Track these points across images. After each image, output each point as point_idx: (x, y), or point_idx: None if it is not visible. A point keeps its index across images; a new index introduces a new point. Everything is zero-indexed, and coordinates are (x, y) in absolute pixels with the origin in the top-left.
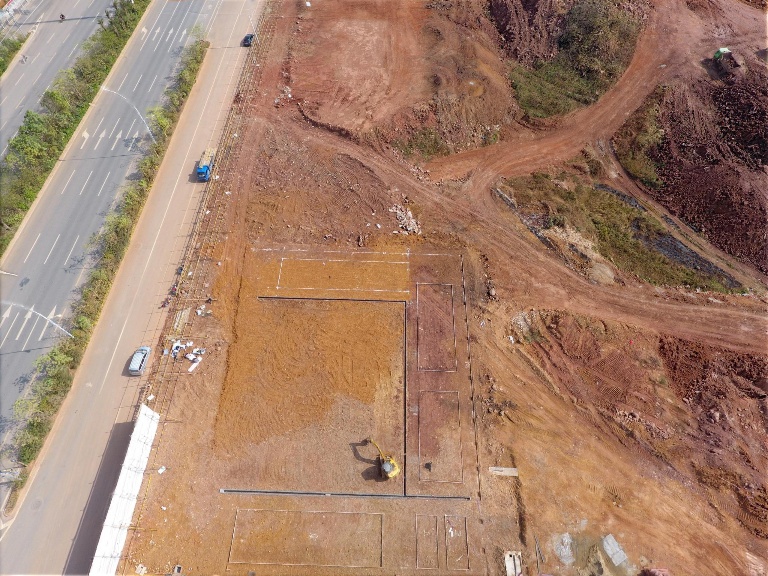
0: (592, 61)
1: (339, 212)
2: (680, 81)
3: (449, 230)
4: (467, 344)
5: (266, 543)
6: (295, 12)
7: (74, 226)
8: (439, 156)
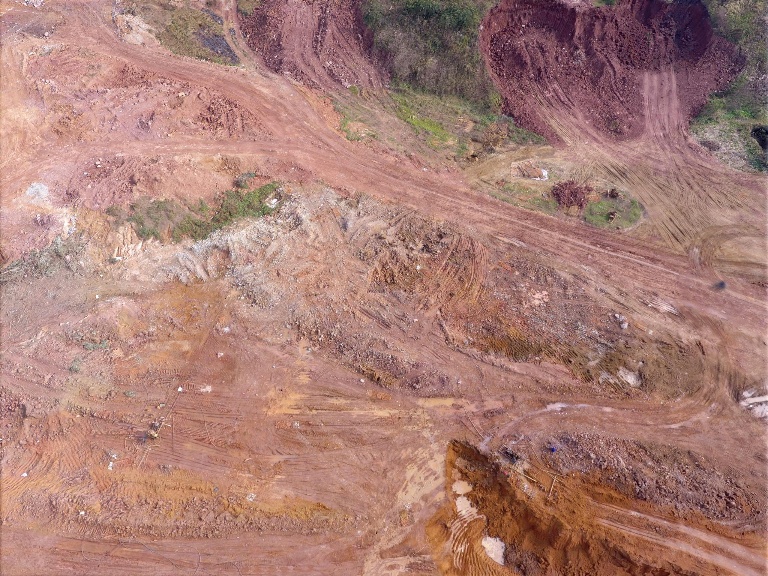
0: None
1: None
2: None
3: None
4: None
5: None
6: None
7: None
8: None
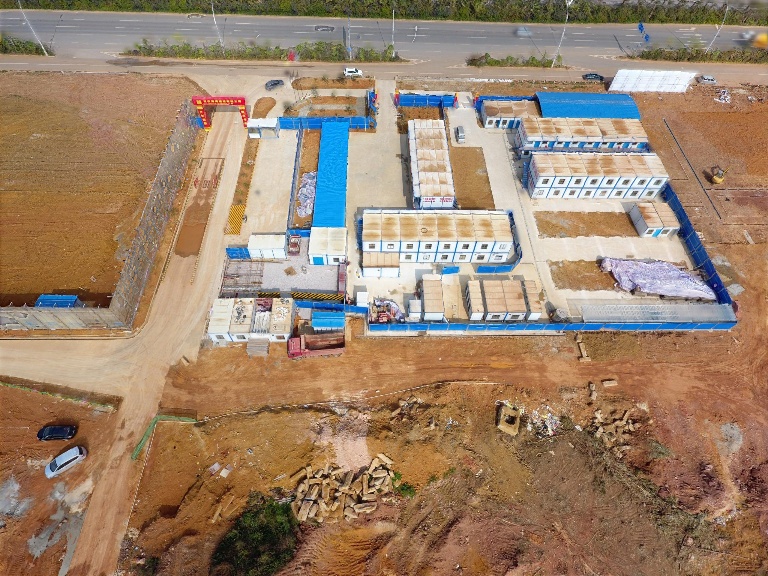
0: None
1: None
2: None
3: None
4: None
5: (650, 136)
6: None
7: (763, 44)
8: None
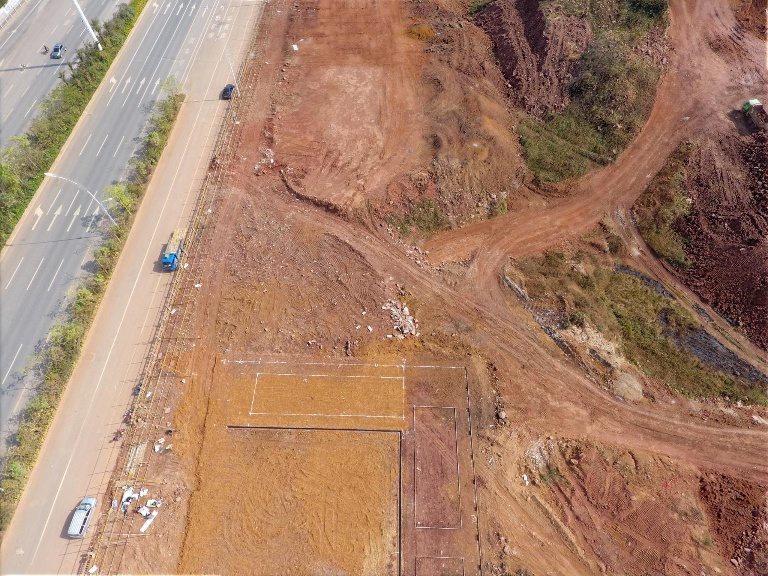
0: (608, 113)
1: (325, 310)
2: (706, 137)
3: (451, 330)
4: (473, 490)
5: None
6: (281, 57)
7: (17, 331)
8: (439, 232)
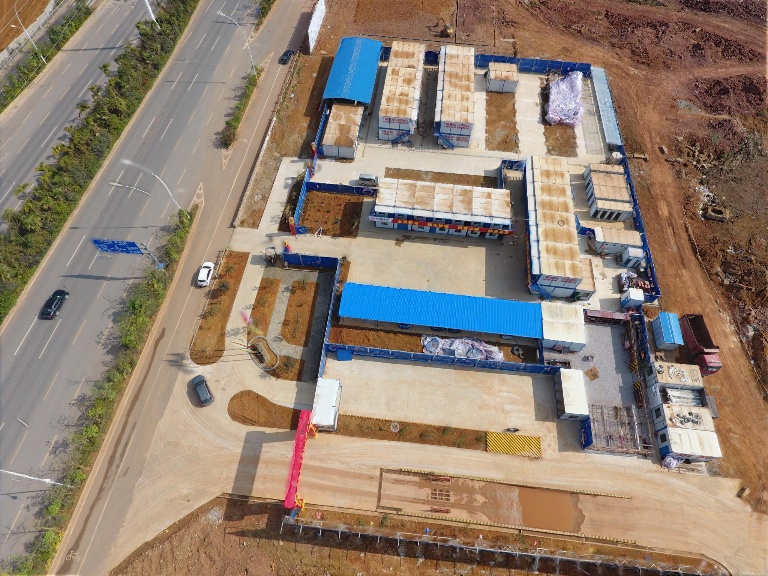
0: None
1: None
2: None
3: None
4: (493, 1)
5: None
6: None
7: None
8: None
